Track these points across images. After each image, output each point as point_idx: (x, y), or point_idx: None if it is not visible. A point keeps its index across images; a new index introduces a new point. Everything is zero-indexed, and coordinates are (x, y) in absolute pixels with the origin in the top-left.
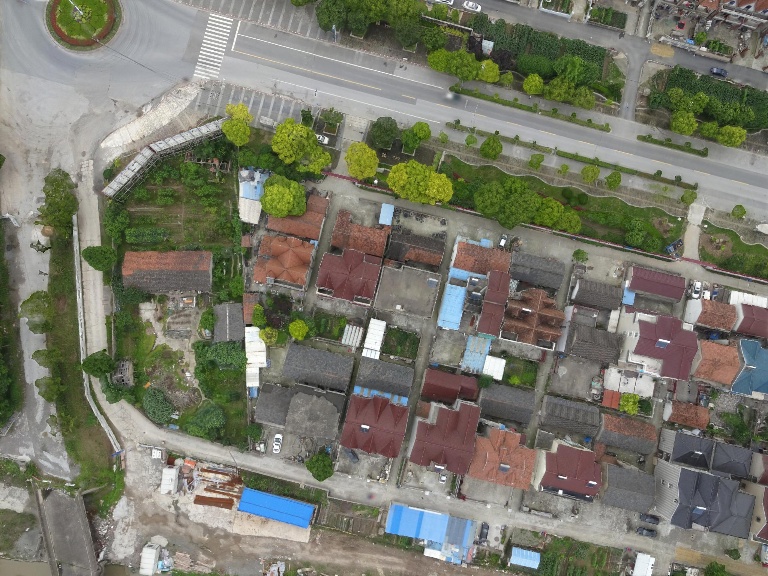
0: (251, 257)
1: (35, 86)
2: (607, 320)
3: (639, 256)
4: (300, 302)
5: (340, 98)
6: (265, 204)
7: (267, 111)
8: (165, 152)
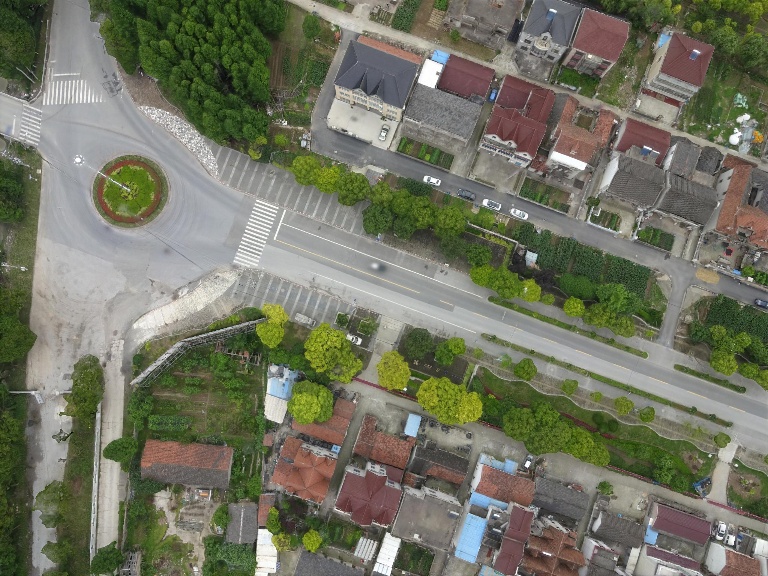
0: (272, 454)
1: (75, 259)
2: (626, 555)
3: (665, 490)
4: (316, 507)
5: (377, 298)
6: (292, 411)
7: (303, 305)
8: (197, 340)
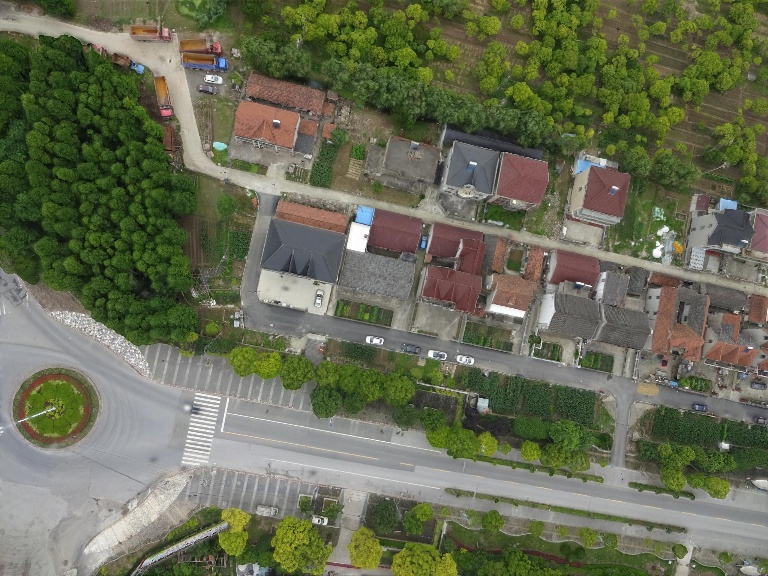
0: None
1: (6, 492)
2: None
3: None
4: None
5: (337, 472)
6: None
7: (262, 494)
8: None
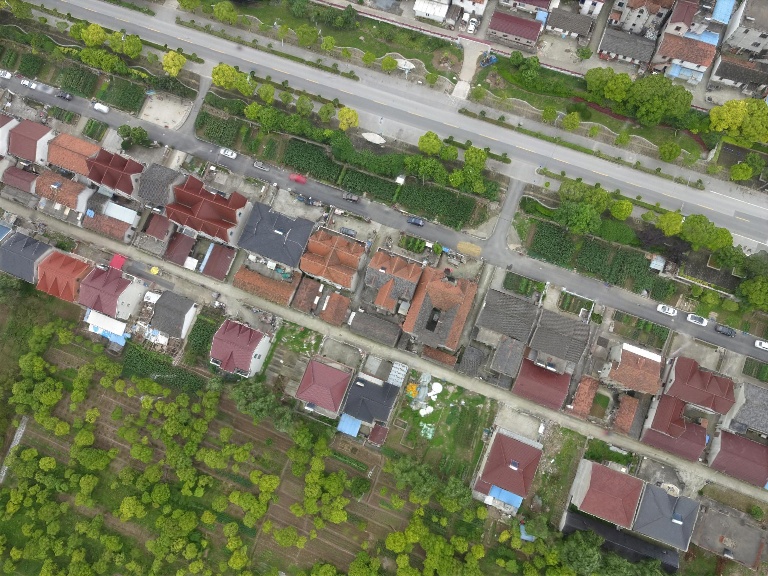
0: None
1: None
2: None
3: None
4: None
5: None
6: None
7: None
8: None
